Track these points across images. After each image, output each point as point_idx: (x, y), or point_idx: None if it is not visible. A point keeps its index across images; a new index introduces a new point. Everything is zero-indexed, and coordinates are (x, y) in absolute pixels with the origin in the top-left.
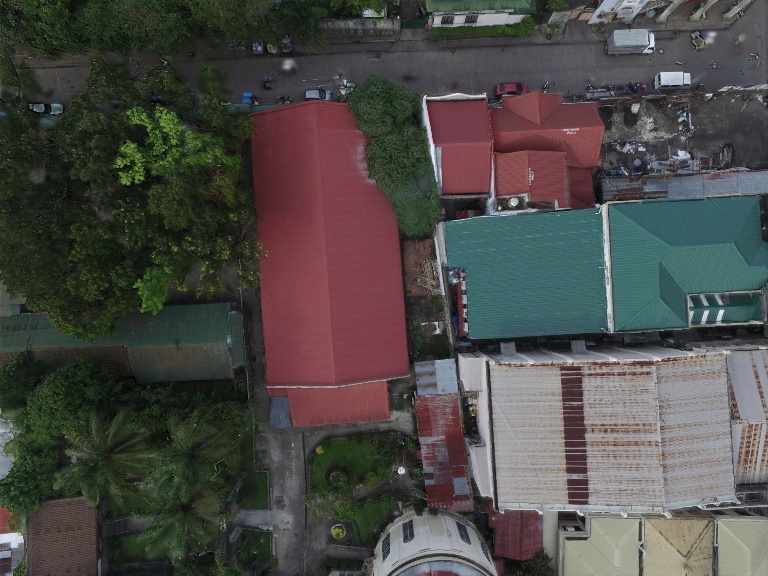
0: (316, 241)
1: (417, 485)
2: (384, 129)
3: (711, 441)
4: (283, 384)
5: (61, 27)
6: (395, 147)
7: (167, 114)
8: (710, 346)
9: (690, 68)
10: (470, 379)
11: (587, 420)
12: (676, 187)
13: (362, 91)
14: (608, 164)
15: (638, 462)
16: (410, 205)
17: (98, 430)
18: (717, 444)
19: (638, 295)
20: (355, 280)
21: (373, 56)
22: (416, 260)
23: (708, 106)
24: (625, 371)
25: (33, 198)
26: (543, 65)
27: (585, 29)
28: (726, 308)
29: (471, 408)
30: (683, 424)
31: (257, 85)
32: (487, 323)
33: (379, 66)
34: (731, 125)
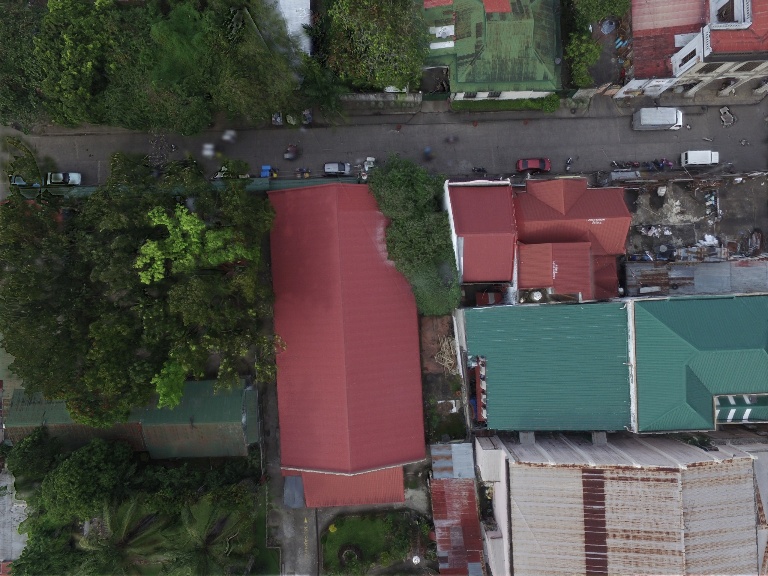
0: (334, 325)
1: (430, 565)
2: (405, 214)
3: (736, 548)
4: (298, 467)
5: (82, 110)
6: (416, 232)
7: (188, 215)
8: (736, 443)
9: (718, 144)
10: (488, 470)
11: (609, 525)
12: (702, 274)
13: (383, 173)
14: (632, 248)
15: (661, 571)
16: (430, 293)
17: (113, 520)
18: (742, 551)
19: (663, 397)
20: (372, 364)
21: (393, 128)
22: (433, 336)
23: (737, 189)
24: (649, 477)
25: (52, 298)
26: (566, 139)
27: (610, 103)
28: (753, 407)
29: (487, 491)
30: (708, 531)
31: (276, 156)
32: (506, 414)
33: (399, 138)
34: (760, 209)
